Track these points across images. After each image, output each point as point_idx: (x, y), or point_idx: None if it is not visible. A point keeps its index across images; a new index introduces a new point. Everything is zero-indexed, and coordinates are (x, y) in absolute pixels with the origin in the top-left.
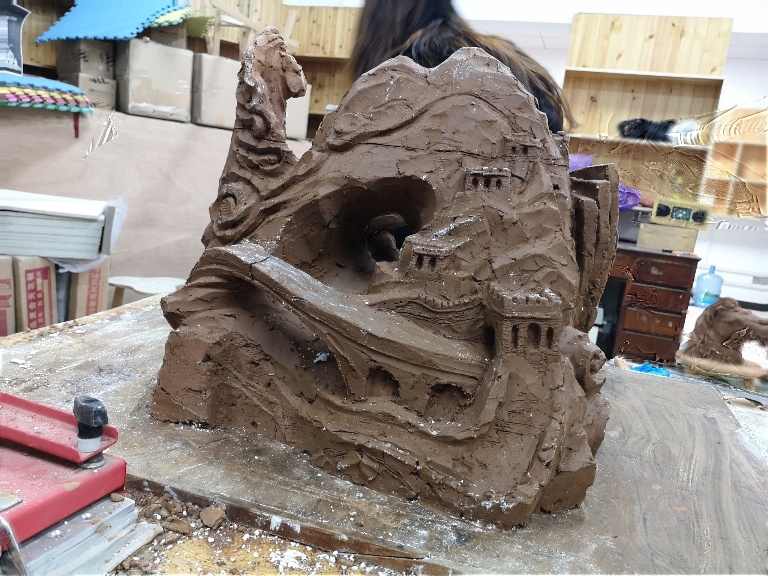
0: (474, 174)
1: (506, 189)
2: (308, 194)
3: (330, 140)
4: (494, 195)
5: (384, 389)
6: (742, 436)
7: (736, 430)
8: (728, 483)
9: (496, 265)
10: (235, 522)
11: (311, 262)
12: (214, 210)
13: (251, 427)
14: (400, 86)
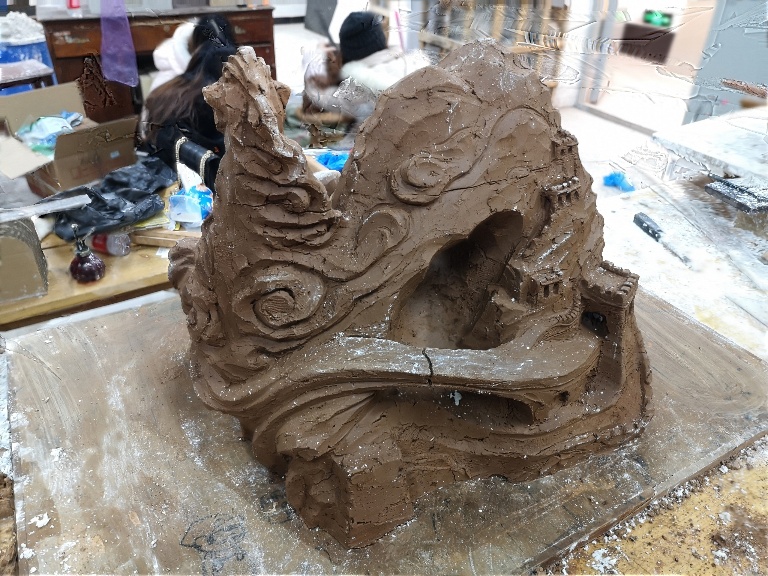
0: (560, 194)
1: (582, 198)
2: (411, 265)
3: (408, 196)
4: (575, 207)
5: (555, 402)
6: None
7: None
8: None
9: (581, 262)
10: (545, 569)
11: (396, 317)
12: (243, 308)
13: (430, 488)
14: (460, 113)
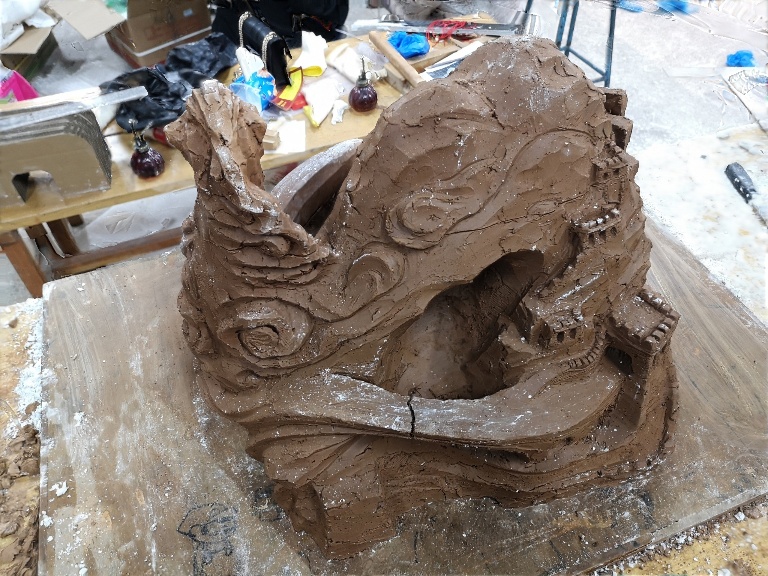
0: None
1: (621, 234)
2: (403, 311)
3: (403, 240)
4: (610, 243)
5: None
6: (653, 220)
7: (645, 214)
8: (691, 296)
9: (612, 297)
10: None
11: (394, 343)
12: (227, 336)
13: (419, 503)
14: (472, 144)
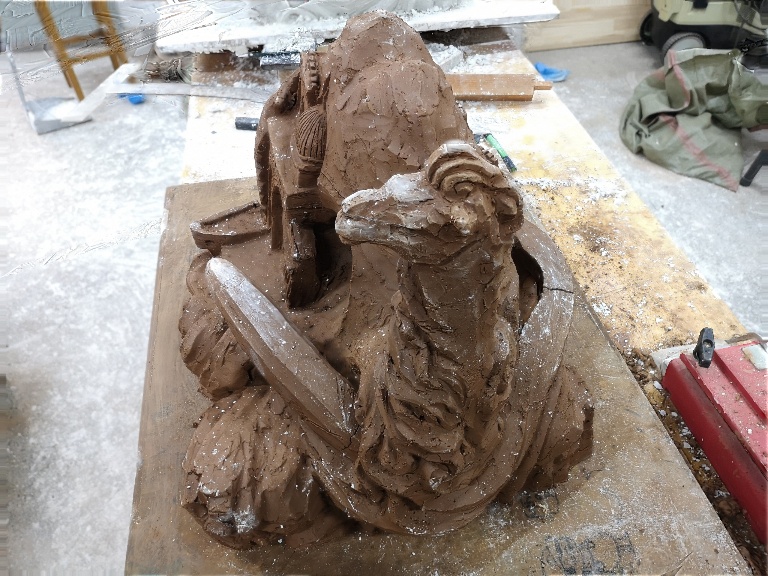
0: None
1: None
2: None
3: None
4: None
5: None
6: None
7: None
8: None
9: None
10: None
11: None
12: None
13: None
14: None
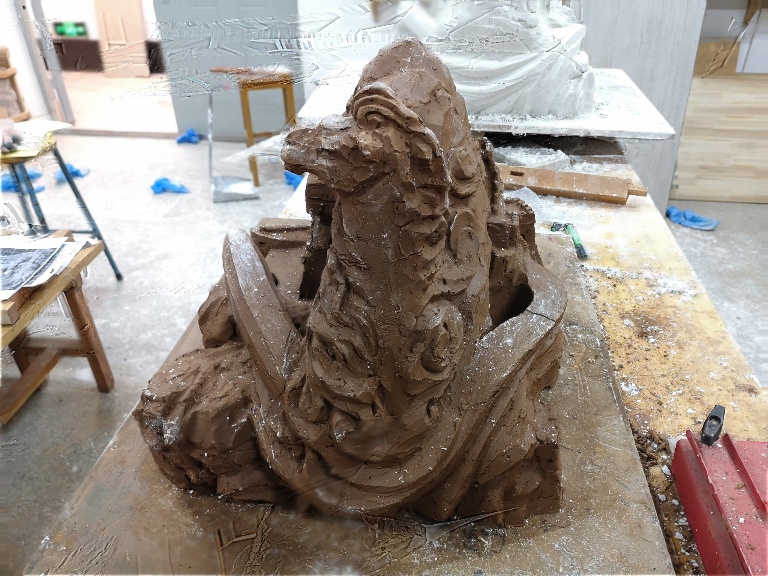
0: None
1: None
2: (487, 249)
3: (467, 190)
4: None
5: None
6: None
7: None
8: None
9: None
10: None
11: None
12: (417, 369)
13: None
14: None
